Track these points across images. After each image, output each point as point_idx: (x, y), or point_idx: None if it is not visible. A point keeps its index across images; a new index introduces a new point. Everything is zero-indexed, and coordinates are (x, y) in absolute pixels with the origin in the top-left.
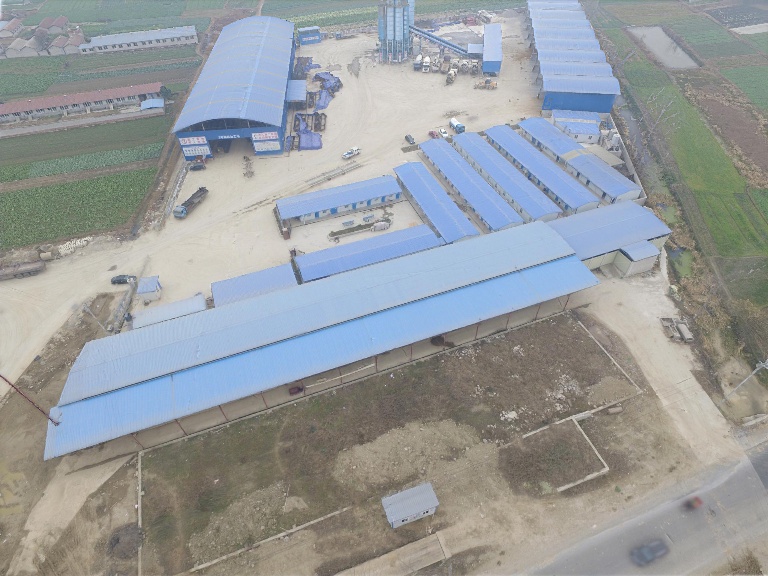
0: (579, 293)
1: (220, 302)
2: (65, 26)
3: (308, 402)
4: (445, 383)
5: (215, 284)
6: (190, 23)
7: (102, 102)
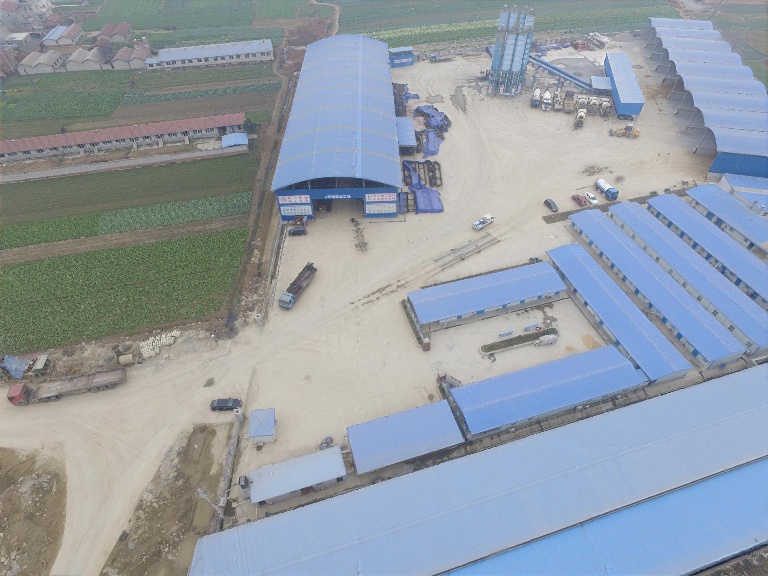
0: None
1: (363, 461)
2: (128, 34)
3: None
4: None
5: (352, 429)
6: (262, 35)
7: (177, 134)
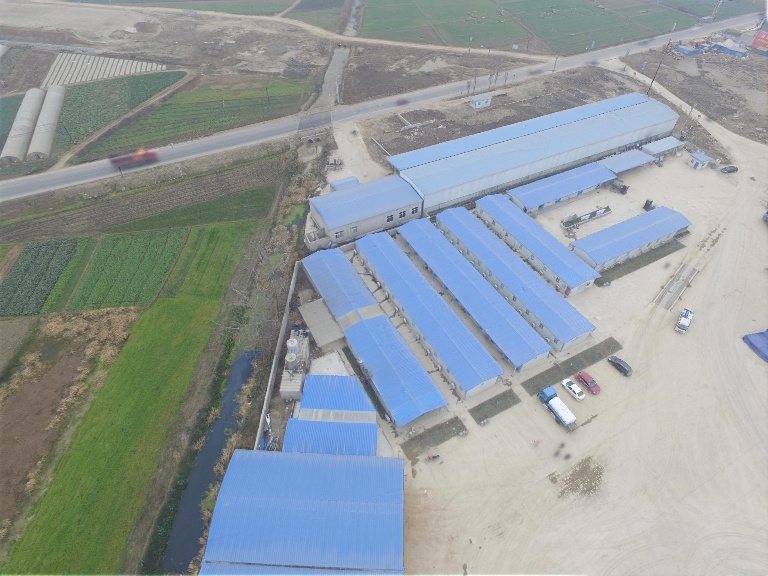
0: None
1: None
2: None
3: None
4: None
5: (654, 158)
6: None
7: None
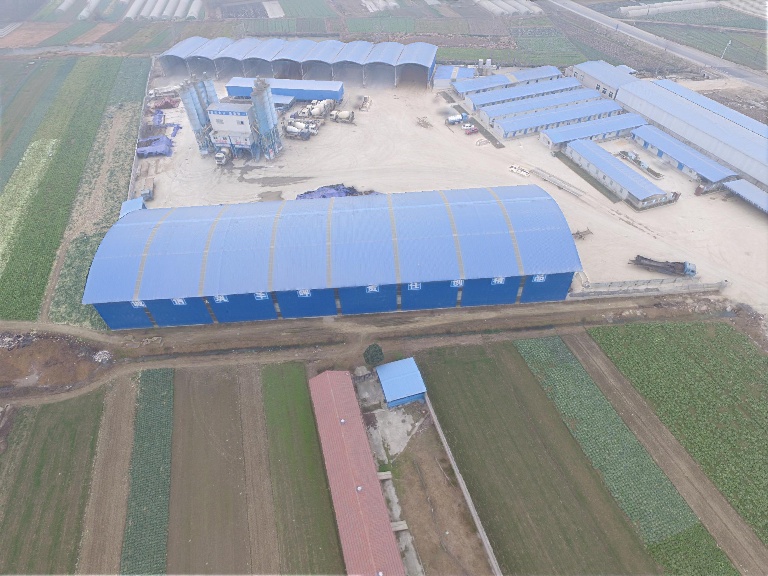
0: None
1: None
2: None
3: None
4: None
5: None
6: None
7: None
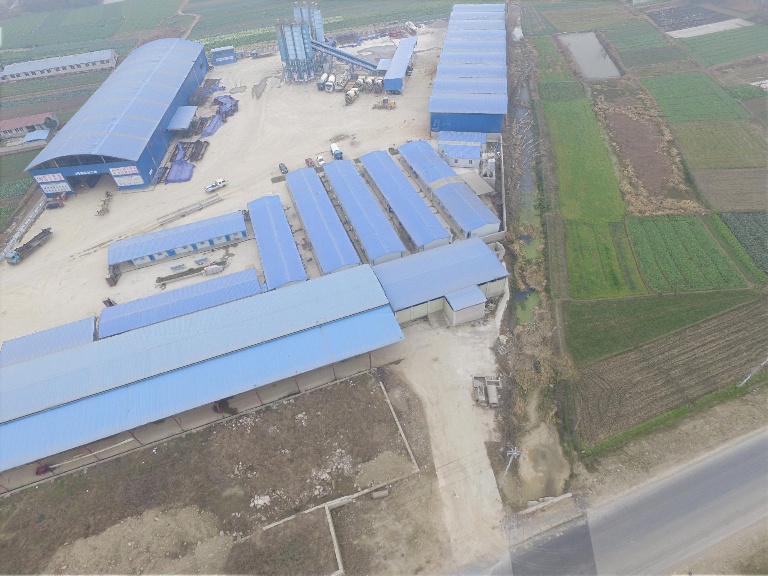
0: (395, 346)
1: (4, 364)
2: None
3: (52, 484)
4: (206, 460)
5: (7, 342)
6: (115, 46)
7: None
